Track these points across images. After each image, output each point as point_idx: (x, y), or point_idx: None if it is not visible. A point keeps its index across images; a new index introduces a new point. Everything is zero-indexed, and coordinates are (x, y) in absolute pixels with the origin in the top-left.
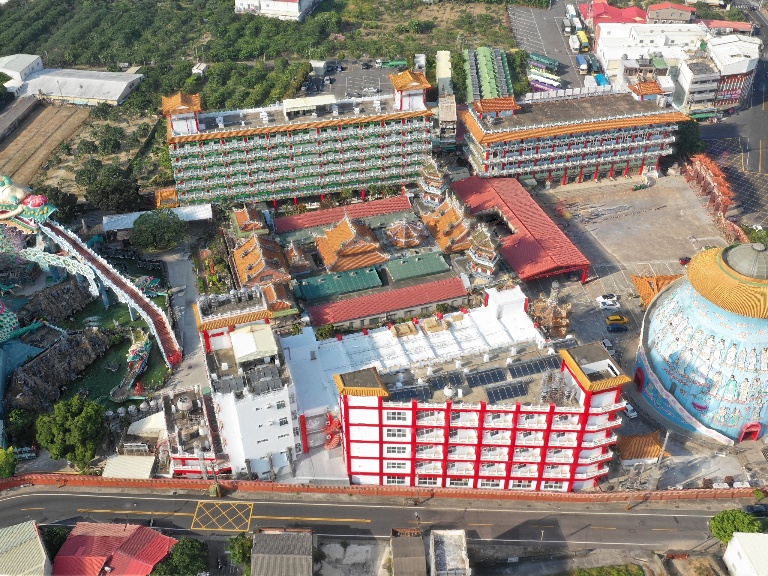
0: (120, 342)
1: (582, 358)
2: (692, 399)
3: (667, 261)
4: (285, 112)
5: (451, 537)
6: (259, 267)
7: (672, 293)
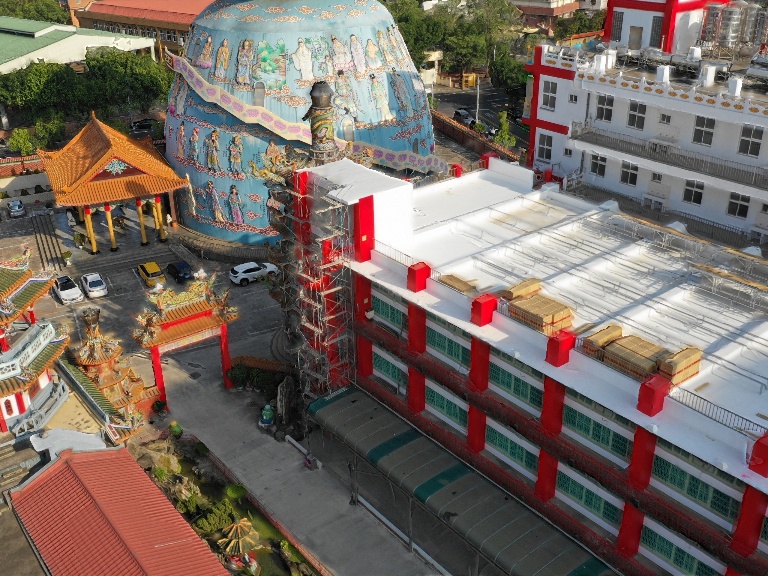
0: None
1: None
2: None
3: None
4: None
5: None
6: None
7: (253, 66)
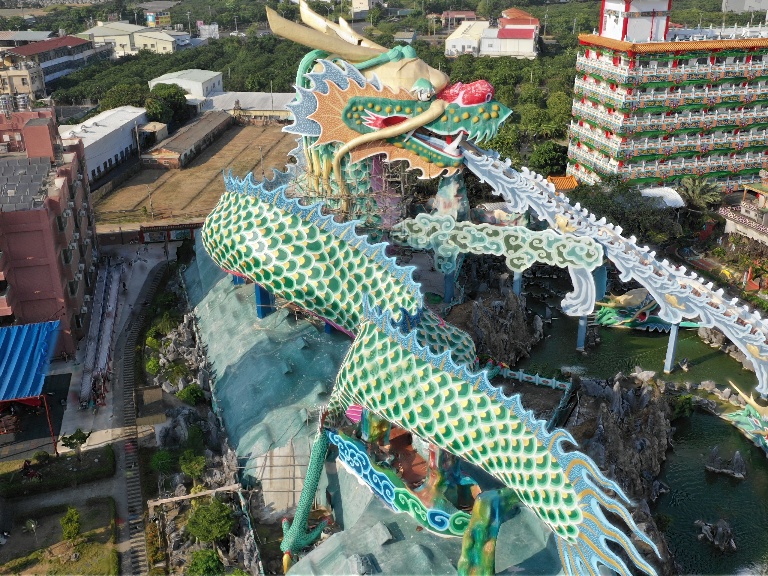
0: (690, 412)
1: None
2: None
3: None
4: None
5: None
6: None
7: None
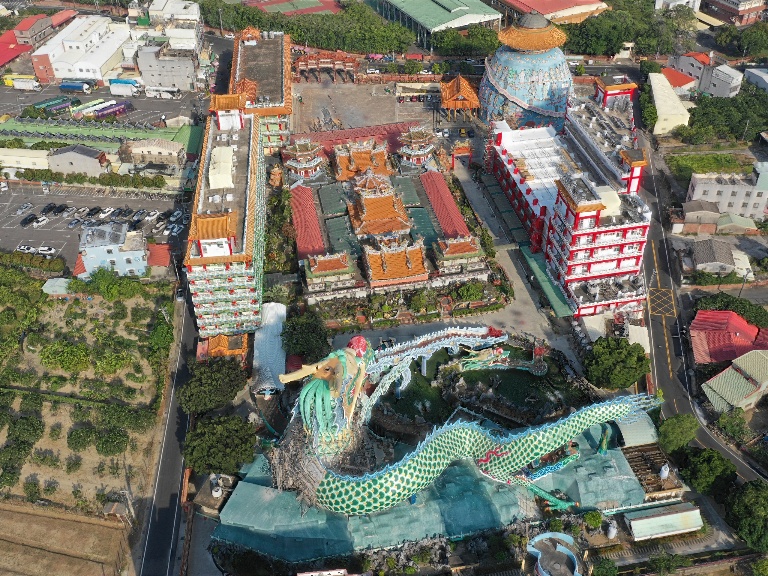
0: None
1: (614, 83)
2: (565, 106)
3: (398, 107)
4: (227, 181)
5: (696, 181)
6: (414, 255)
7: (507, 75)
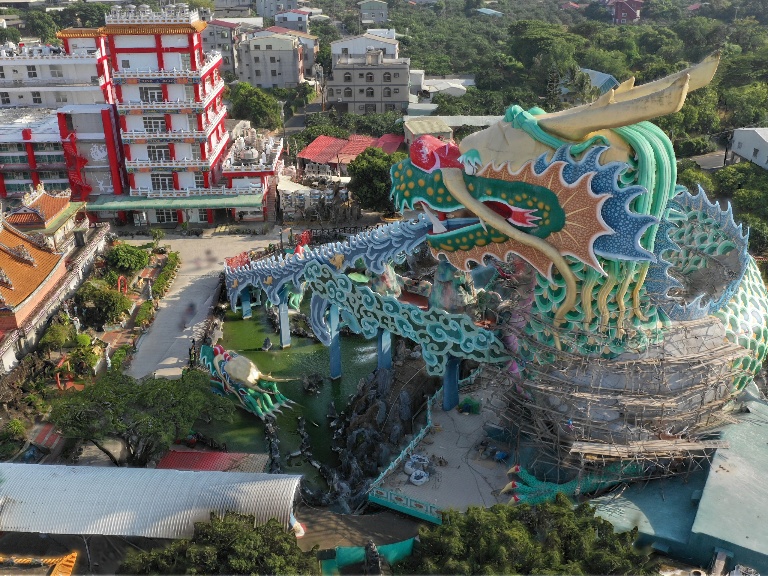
0: None
1: None
2: None
3: None
4: None
5: None
6: (9, 243)
7: None
